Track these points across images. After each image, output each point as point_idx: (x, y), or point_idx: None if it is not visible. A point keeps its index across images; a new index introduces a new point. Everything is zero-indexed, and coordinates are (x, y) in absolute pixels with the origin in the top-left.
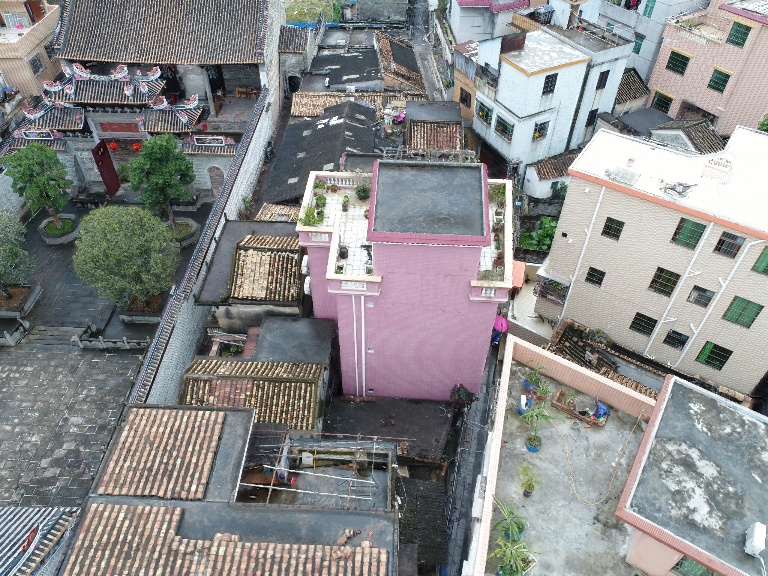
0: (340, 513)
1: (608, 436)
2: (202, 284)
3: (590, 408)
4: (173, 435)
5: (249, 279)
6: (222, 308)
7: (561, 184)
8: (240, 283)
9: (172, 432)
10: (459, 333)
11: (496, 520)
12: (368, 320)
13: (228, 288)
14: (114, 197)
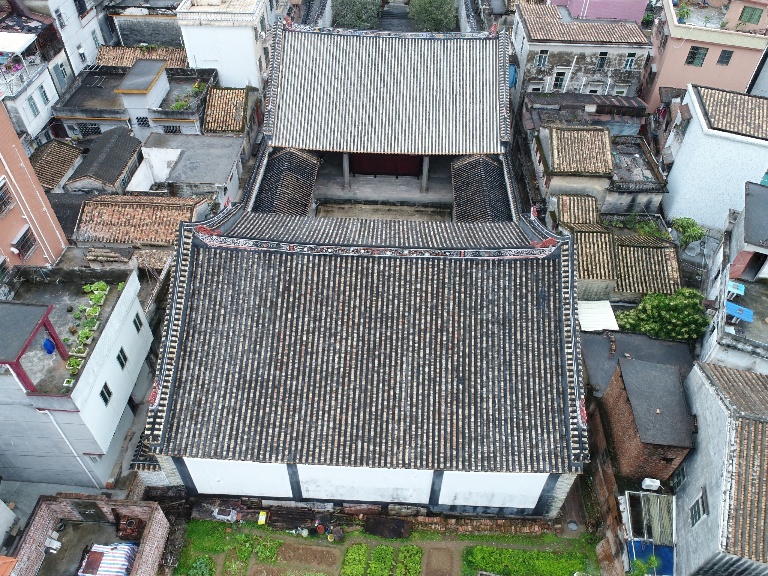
0: (615, 21)
1: (709, 10)
2: (491, 8)
3: (701, 3)
4: (540, 8)
5: (517, 3)
6: (503, 18)
7: (649, 1)
8: (513, 5)
9: (539, 8)
10: (631, 9)
11: (676, 14)
12: (590, 1)
13: (508, 7)
14: (383, 10)
